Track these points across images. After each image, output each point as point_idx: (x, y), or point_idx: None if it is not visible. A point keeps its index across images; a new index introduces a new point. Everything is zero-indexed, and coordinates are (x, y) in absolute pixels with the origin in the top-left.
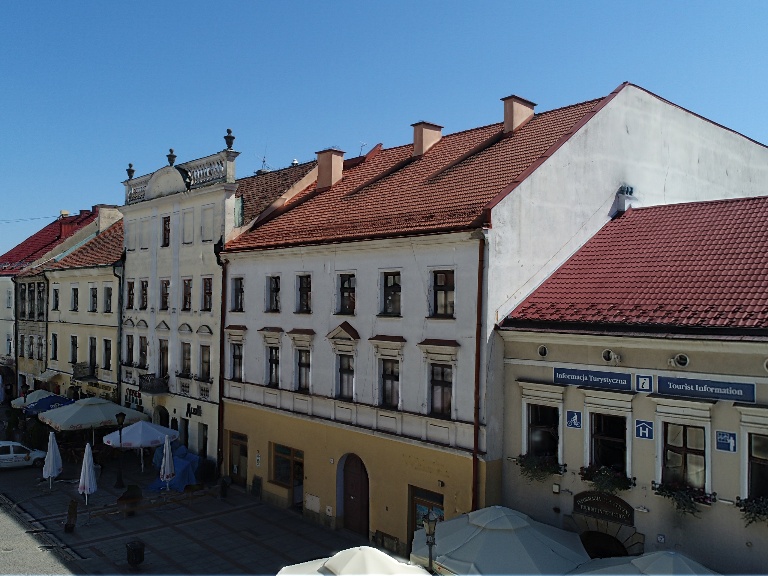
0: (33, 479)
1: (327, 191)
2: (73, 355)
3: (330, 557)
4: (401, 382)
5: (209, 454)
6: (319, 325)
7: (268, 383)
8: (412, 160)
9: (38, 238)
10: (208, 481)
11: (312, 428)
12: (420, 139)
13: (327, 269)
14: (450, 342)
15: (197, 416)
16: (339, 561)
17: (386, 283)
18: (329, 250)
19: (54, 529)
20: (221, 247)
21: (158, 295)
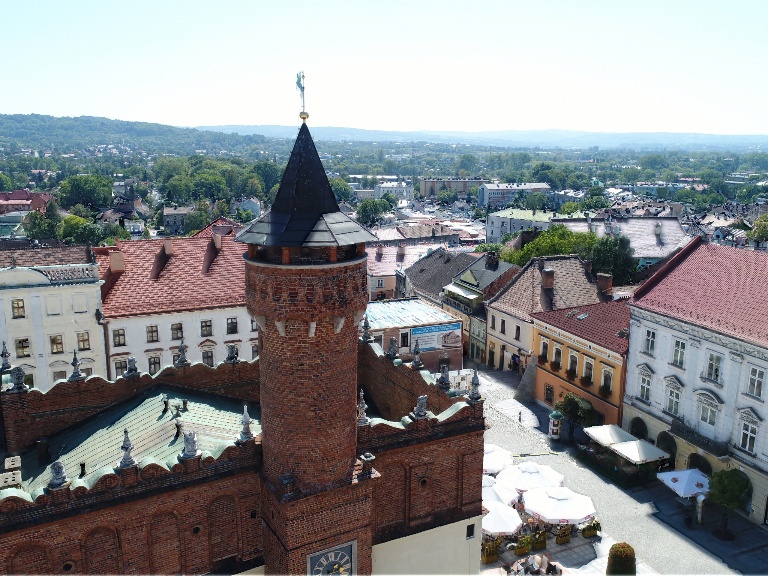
0: None
1: (125, 273)
2: None
3: None
4: (240, 355)
5: None
6: (190, 343)
7: None
8: (168, 256)
9: None
10: None
11: None
12: (171, 246)
13: (194, 320)
14: None
15: None
16: None
17: (227, 322)
18: (197, 312)
19: None
20: None
21: (13, 349)
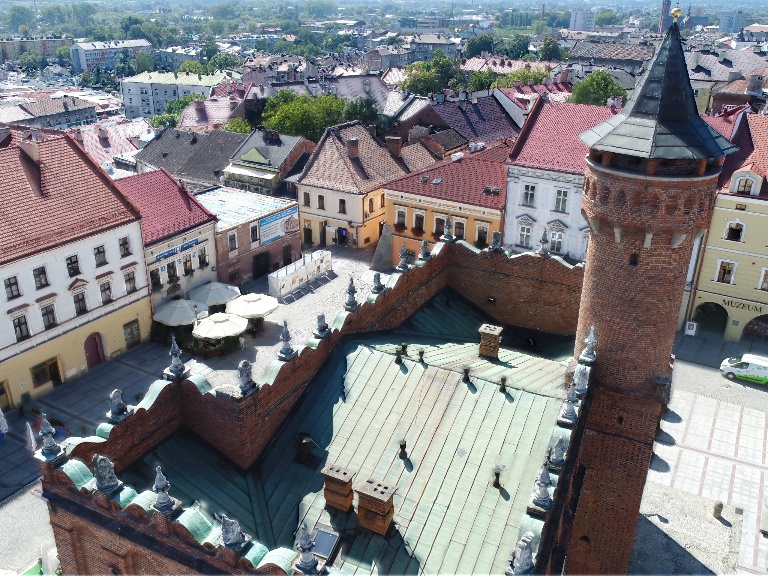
0: None
1: None
2: None
3: (214, 322)
4: None
5: None
6: None
7: None
8: None
9: None
10: None
11: None
12: None
13: None
14: (134, 263)
15: None
16: None
17: (94, 253)
18: None
19: None
20: None
21: None
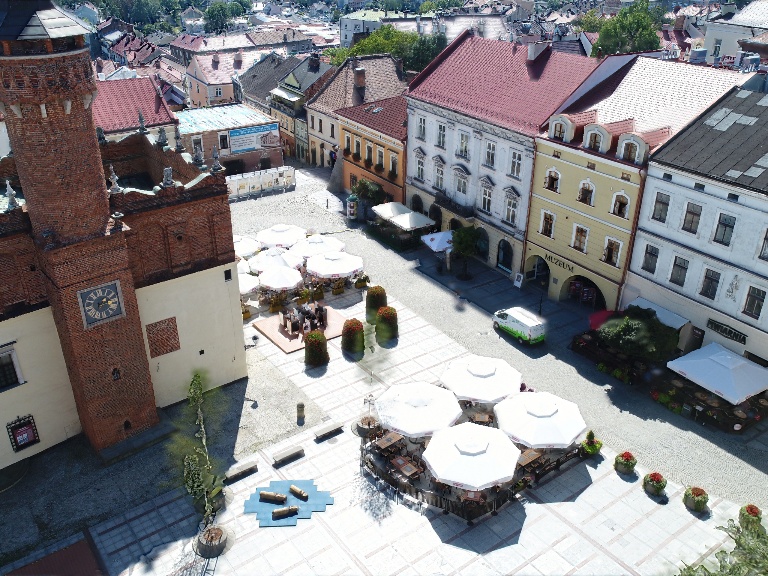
0: None
1: None
2: None
3: None
4: None
5: None
6: (3, 153)
7: None
8: None
9: None
10: None
11: None
12: None
13: None
14: None
15: None
16: None
17: None
18: None
19: None
20: None
21: None
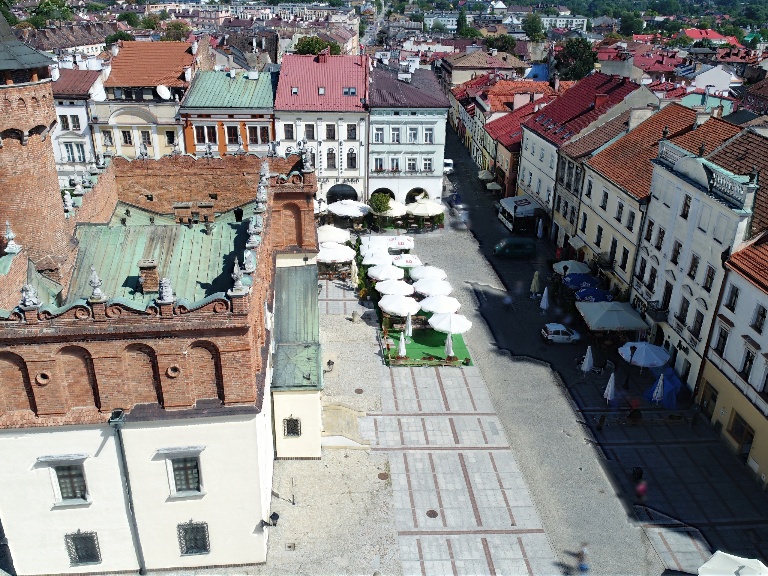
0: (573, 359)
1: None
2: (598, 238)
3: (744, 565)
4: None
5: (689, 383)
6: None
7: (741, 371)
8: None
9: (575, 94)
10: (685, 402)
11: (765, 424)
12: None
13: None
14: None
15: (685, 353)
16: (747, 575)
17: None
18: None
19: (591, 424)
20: (727, 256)
21: (671, 249)
